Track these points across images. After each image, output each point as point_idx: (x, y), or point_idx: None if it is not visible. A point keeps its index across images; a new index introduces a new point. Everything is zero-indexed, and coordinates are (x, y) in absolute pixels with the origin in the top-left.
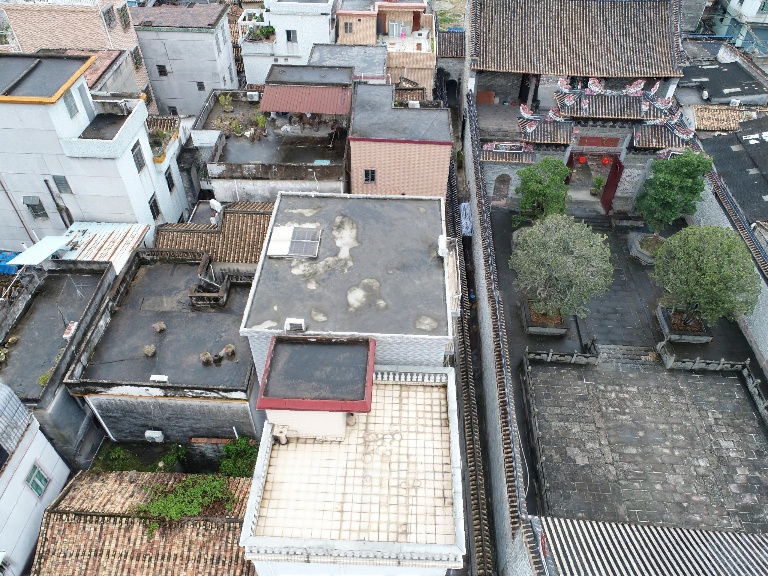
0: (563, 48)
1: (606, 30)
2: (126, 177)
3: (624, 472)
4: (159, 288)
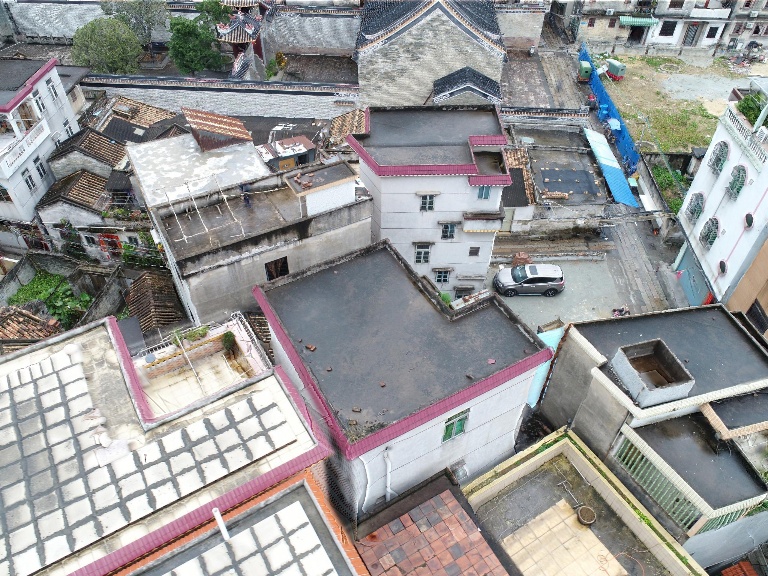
0: (388, 3)
1: (406, 6)
2: None
3: None
4: None
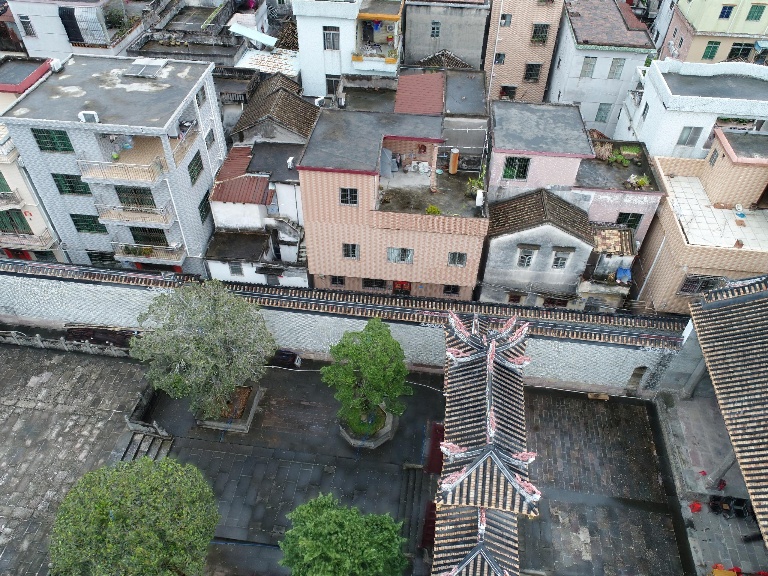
0: None
1: None
2: (304, 36)
3: (1, 411)
4: (225, 87)
